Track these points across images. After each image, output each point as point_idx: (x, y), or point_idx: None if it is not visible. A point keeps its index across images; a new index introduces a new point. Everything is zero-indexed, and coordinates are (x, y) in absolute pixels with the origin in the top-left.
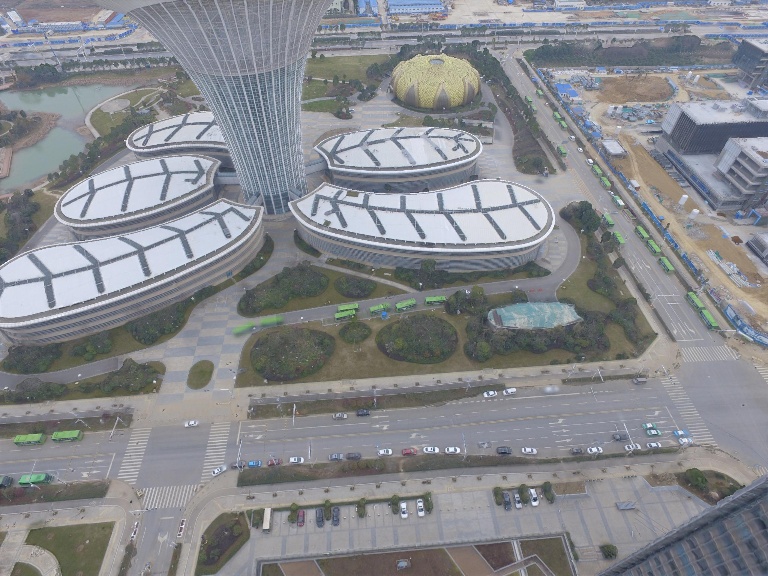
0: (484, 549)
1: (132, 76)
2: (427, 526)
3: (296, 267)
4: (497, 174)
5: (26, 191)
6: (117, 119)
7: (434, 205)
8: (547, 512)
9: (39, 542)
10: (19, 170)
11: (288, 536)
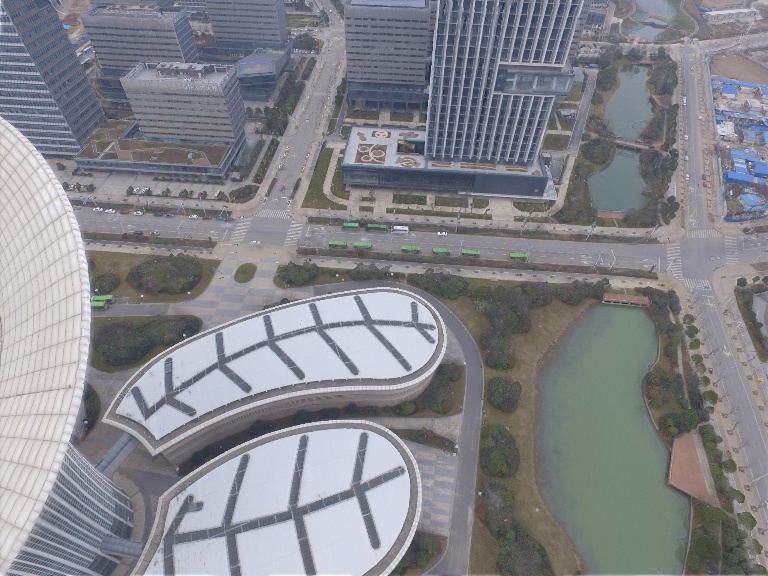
0: (115, 158)
1: None
2: (138, 186)
3: (117, 355)
4: None
5: None
6: None
7: None
8: (74, 182)
9: (340, 205)
10: None
11: (210, 191)
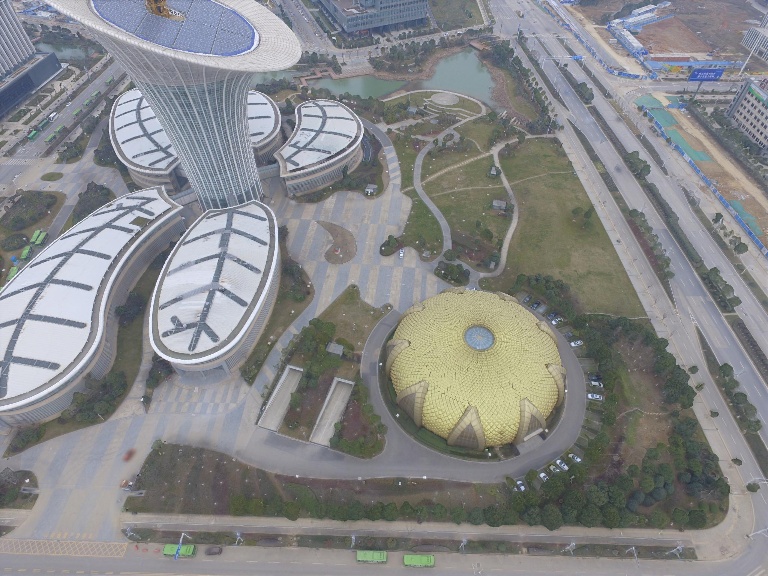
0: None
1: (513, 96)
2: None
3: None
4: (169, 409)
5: (292, 85)
6: (410, 102)
7: (64, 276)
8: None
9: None
10: (353, 84)
11: None
